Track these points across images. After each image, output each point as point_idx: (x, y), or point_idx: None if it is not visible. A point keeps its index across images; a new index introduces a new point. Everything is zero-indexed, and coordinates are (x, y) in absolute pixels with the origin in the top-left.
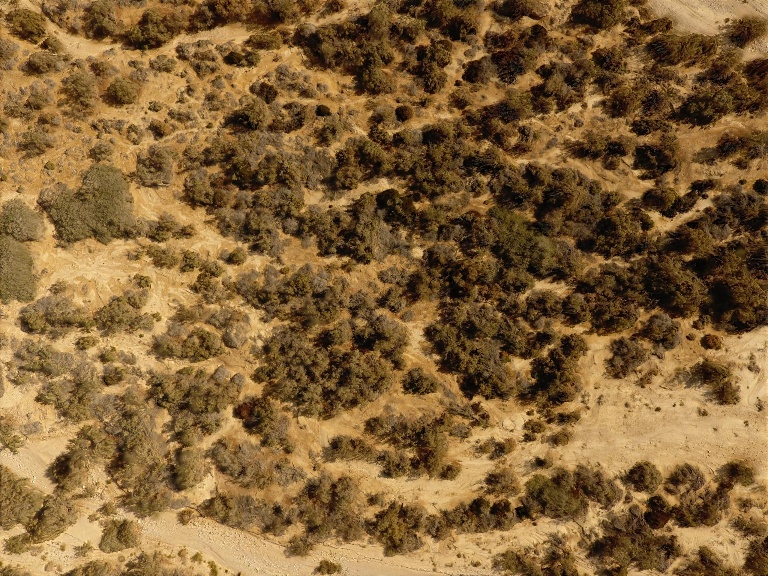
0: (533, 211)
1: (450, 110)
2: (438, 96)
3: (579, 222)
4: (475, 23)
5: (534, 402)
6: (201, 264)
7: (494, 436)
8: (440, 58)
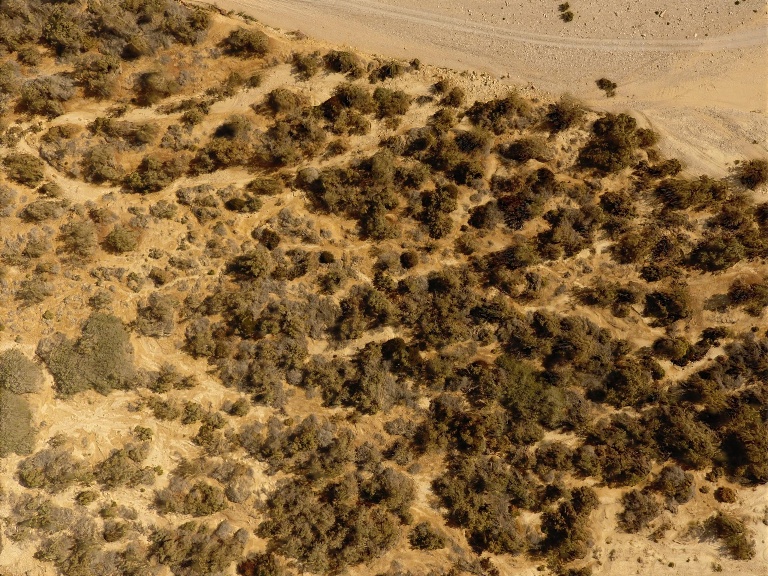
0: (542, 360)
1: (456, 256)
2: (444, 241)
3: (589, 373)
4: (481, 167)
5: (544, 557)
6: (203, 416)
7: None
8: (446, 207)
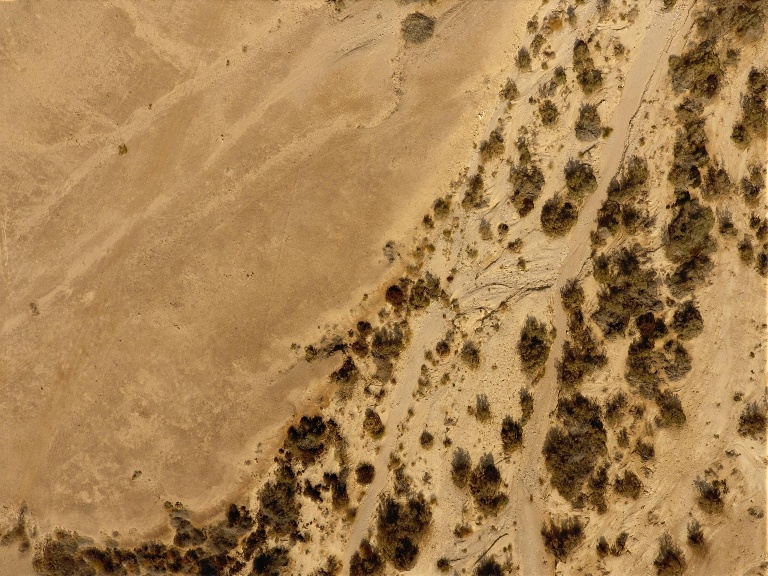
0: None
1: None
2: None
3: None
4: None
5: None
6: None
7: (766, 189)
8: None
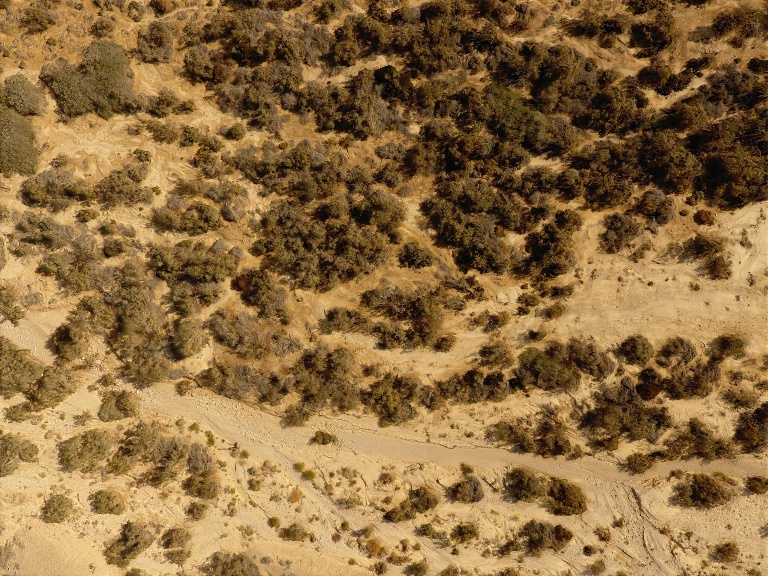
0: (529, 89)
1: None
2: None
3: (575, 98)
4: None
5: (528, 276)
6: (200, 139)
7: (488, 309)
8: None
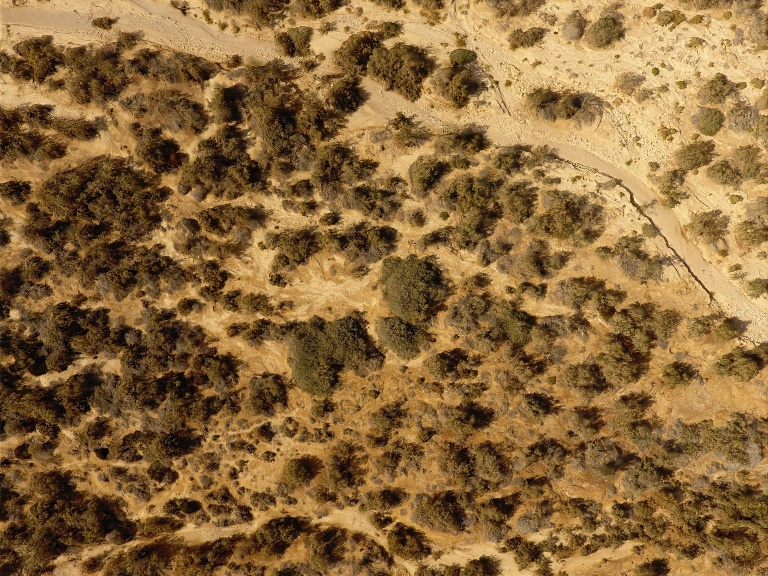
0: None
1: None
2: None
3: None
4: None
5: None
6: (221, 299)
7: None
8: None
